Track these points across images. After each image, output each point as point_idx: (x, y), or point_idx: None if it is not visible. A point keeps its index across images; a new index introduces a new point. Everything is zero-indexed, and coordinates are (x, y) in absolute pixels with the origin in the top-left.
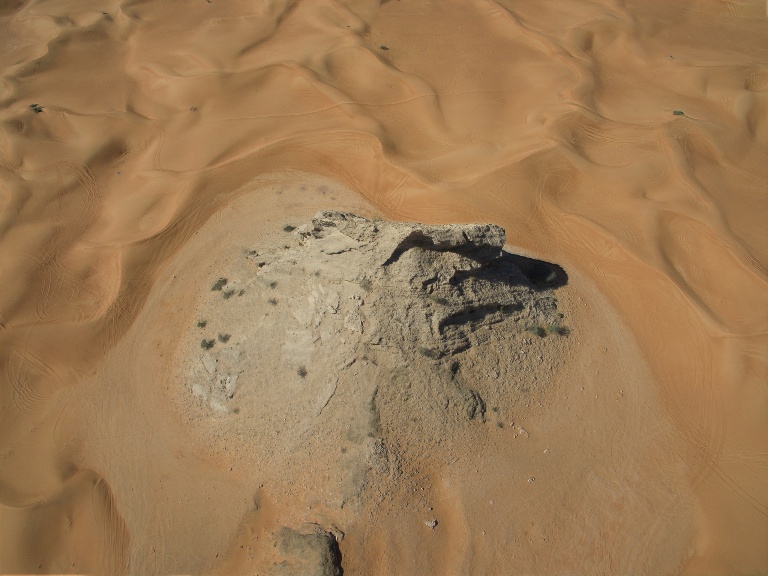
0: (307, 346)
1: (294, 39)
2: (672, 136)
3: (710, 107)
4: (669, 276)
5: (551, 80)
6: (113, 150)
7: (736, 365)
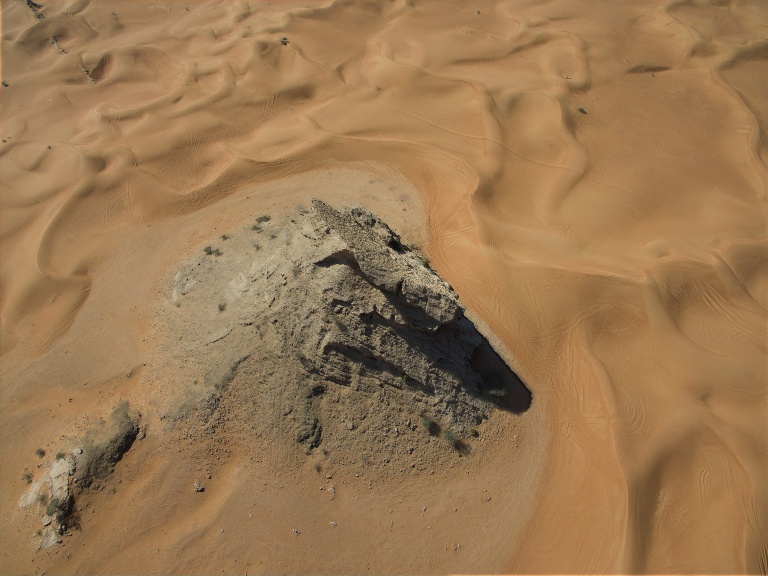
0: (239, 291)
1: (511, 69)
2: None
3: None
4: (629, 490)
5: (727, 222)
6: (303, 92)
7: None
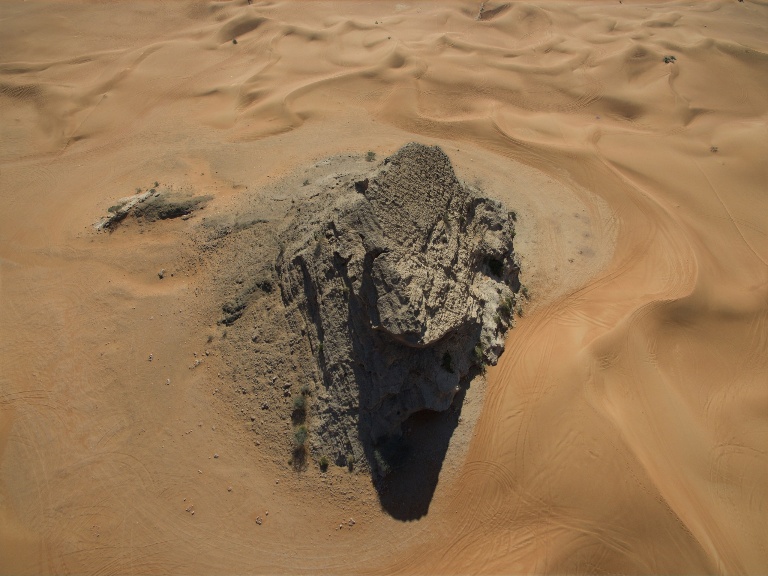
0: None
1: None
2: None
3: None
4: None
5: None
6: (629, 109)
7: None
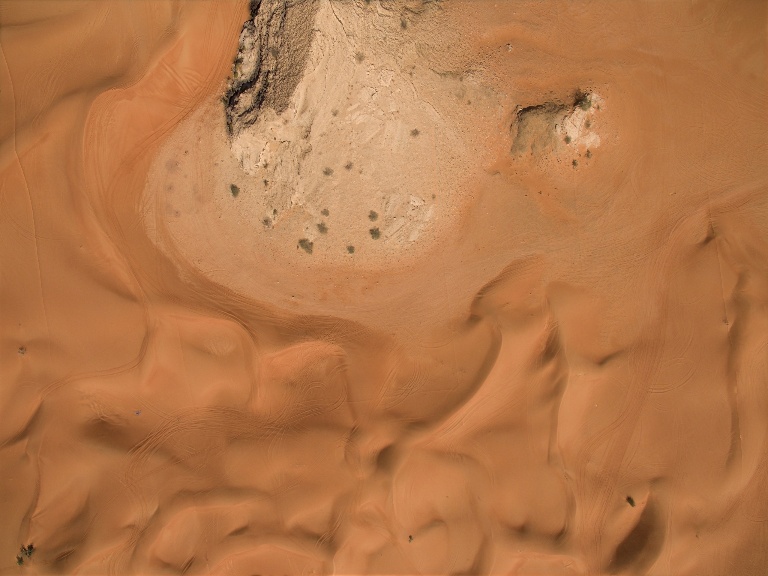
0: (397, 127)
1: None
2: None
3: None
4: None
5: None
6: (101, 432)
7: None
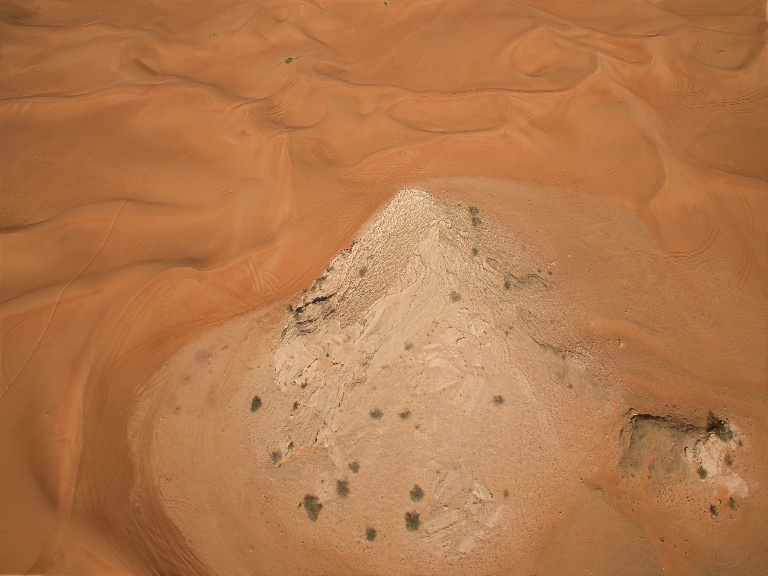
0: (478, 385)
1: None
2: (312, 74)
3: (286, 46)
4: (448, 134)
5: (185, 109)
6: None
7: (524, 137)
